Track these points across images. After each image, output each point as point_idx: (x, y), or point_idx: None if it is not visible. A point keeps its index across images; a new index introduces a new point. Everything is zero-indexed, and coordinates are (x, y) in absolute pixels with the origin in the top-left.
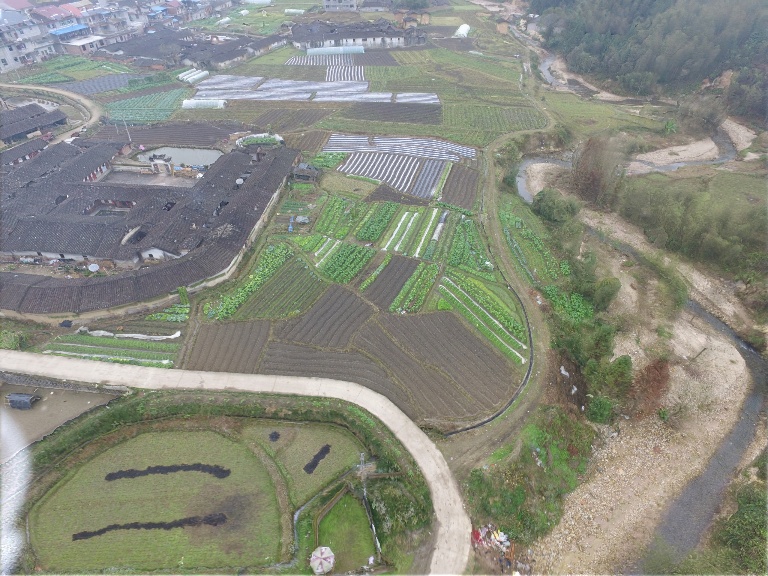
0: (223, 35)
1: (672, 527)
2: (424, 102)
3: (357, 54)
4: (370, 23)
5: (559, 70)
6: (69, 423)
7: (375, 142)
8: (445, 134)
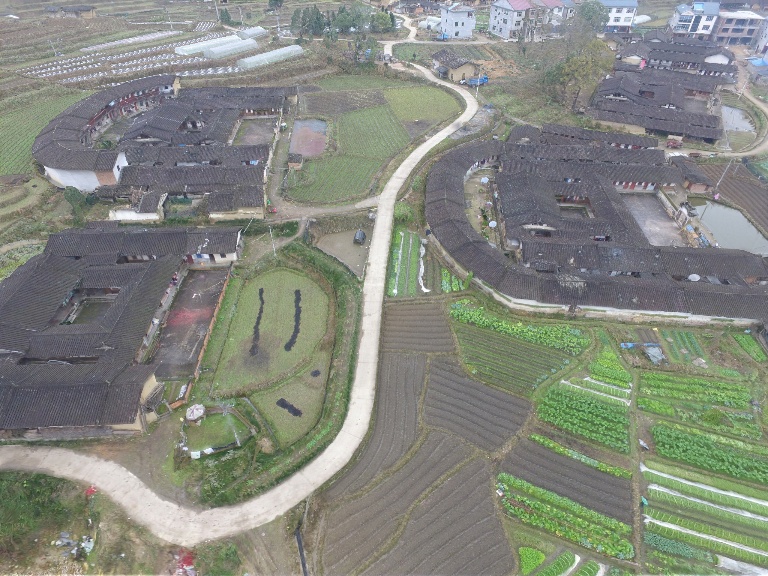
0: None
1: None
2: None
3: None
4: None
5: None
6: (335, 260)
7: None
8: None
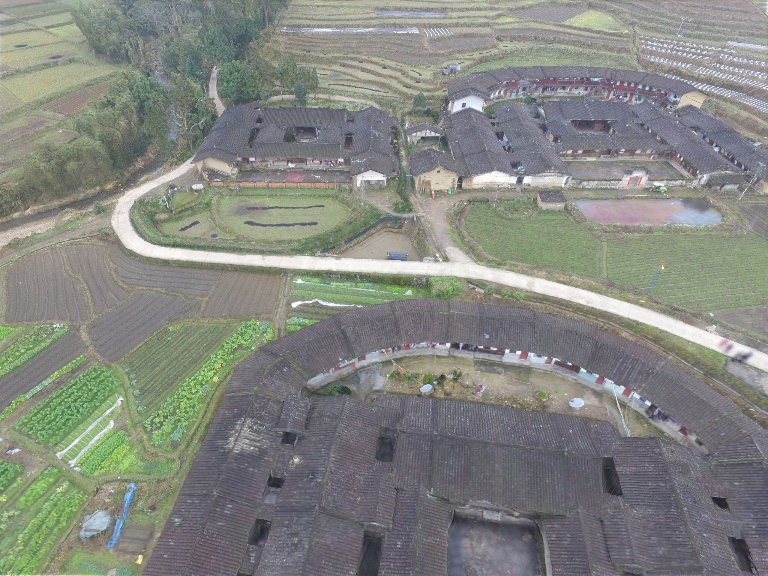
0: None
1: (8, 227)
2: None
3: None
4: None
5: None
6: None
7: None
8: None
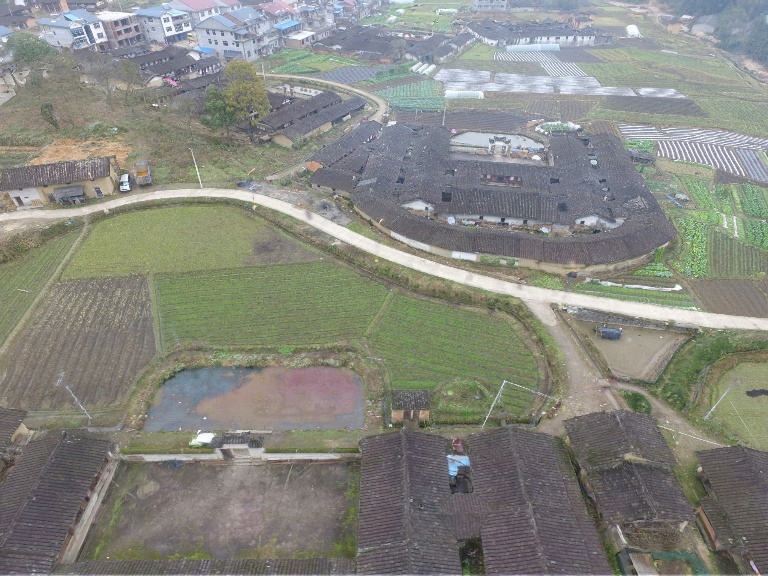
0: (404, 32)
1: None
2: (672, 97)
3: (554, 51)
4: (537, 22)
5: (758, 70)
6: (679, 350)
7: (666, 132)
8: (725, 126)
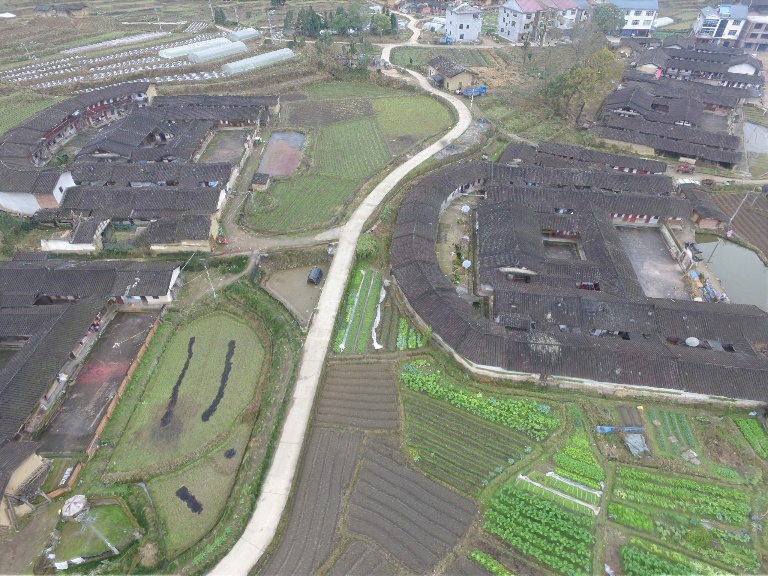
0: None
1: None
2: None
3: None
4: None
5: None
6: (281, 304)
7: None
8: None
